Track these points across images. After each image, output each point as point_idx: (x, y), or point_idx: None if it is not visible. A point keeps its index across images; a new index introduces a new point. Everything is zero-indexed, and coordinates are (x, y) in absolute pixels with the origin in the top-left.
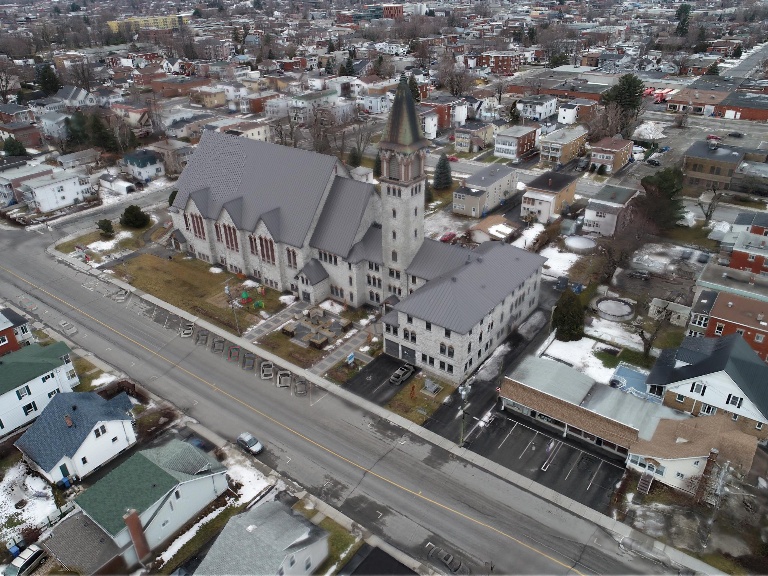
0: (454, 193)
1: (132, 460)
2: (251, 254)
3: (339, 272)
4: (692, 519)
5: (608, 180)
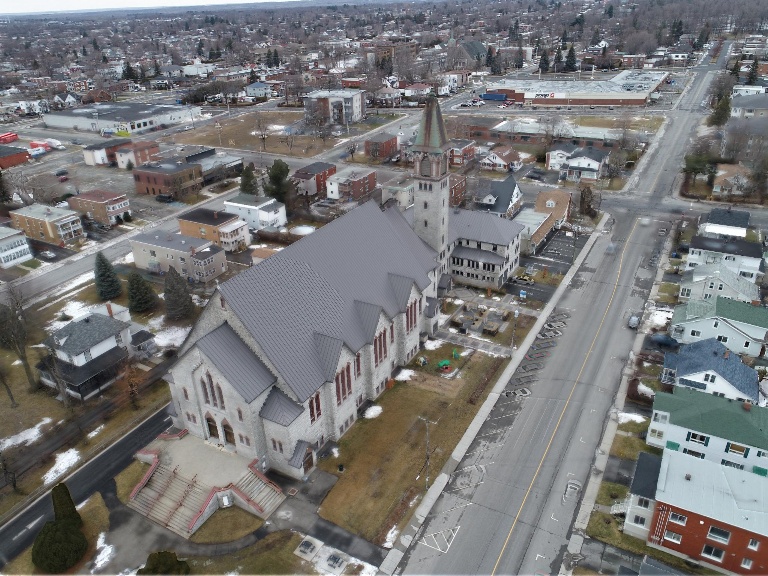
0: (203, 261)
1: (724, 315)
2: None
3: None
4: (583, 219)
5: (147, 220)
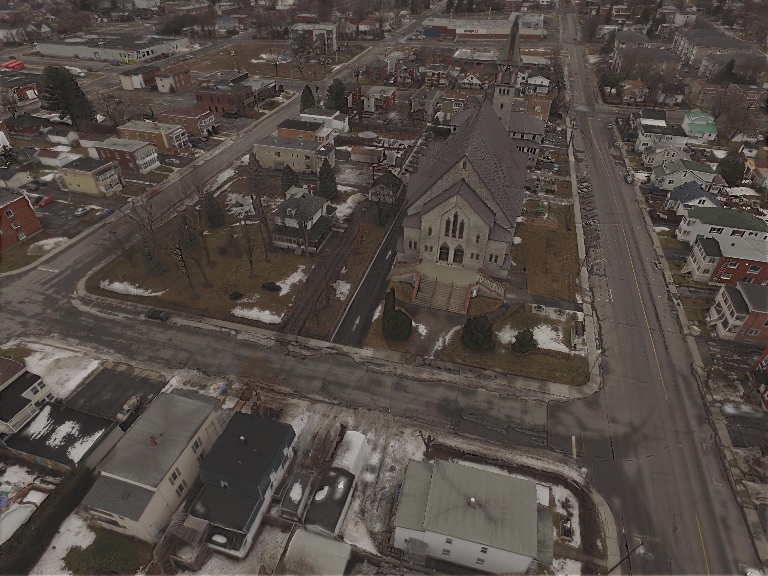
0: None
1: (690, 169)
2: None
3: None
4: (557, 120)
5: (230, 132)
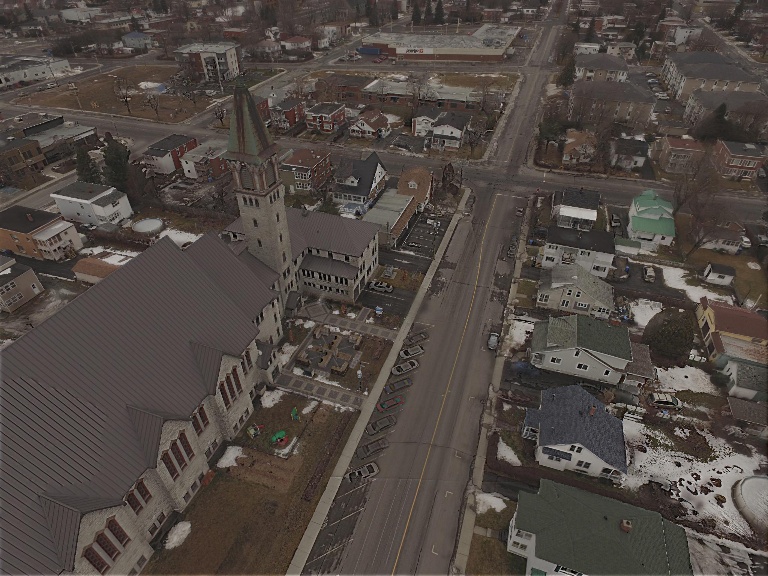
0: None
1: (585, 345)
2: (199, 438)
3: (266, 323)
4: (446, 198)
5: None
